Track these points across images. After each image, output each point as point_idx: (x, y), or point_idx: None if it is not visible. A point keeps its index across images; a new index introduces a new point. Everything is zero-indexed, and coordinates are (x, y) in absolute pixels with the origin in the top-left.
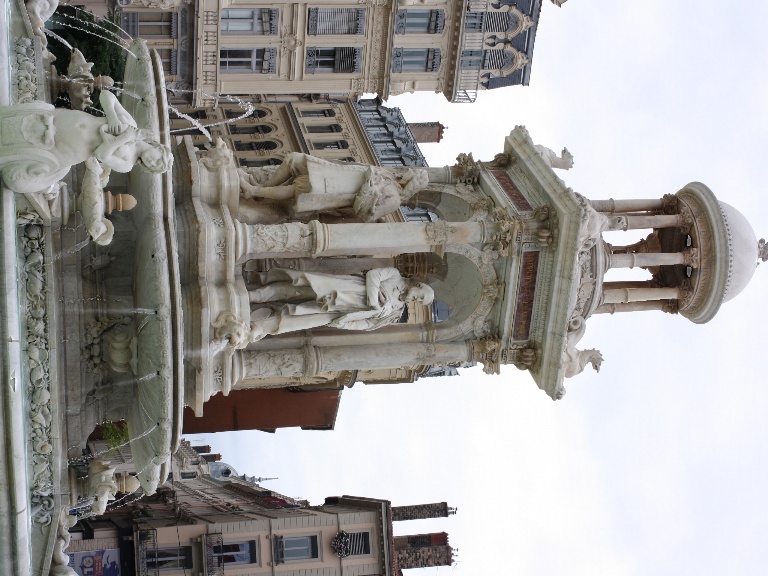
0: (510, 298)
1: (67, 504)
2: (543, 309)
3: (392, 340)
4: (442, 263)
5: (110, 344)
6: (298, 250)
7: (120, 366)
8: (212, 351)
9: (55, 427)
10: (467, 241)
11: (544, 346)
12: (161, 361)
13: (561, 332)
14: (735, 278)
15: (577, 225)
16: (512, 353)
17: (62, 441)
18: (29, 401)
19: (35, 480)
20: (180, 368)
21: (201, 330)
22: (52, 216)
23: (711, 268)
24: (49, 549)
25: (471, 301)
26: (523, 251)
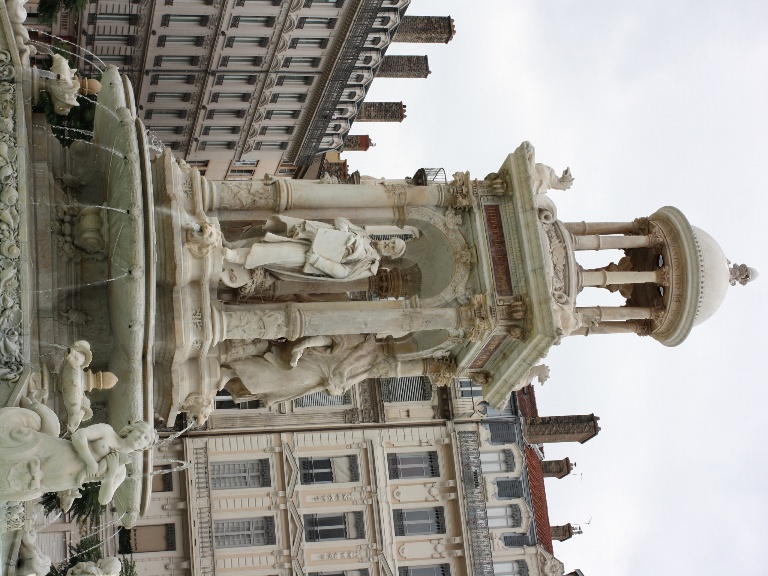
0: (483, 252)
1: (37, 373)
2: (518, 258)
3: (375, 308)
4: (414, 270)
5: (81, 215)
6: (263, 200)
7: (91, 231)
8: (183, 219)
9: (23, 230)
10: (426, 197)
11: (529, 290)
12: (127, 149)
13: (541, 265)
14: (707, 256)
15: (524, 158)
16: (501, 310)
17: (33, 332)
18: None
19: (2, 292)
20: (147, 164)
21: (172, 223)
22: (23, 69)
23: (678, 242)
24: (16, 390)
25: (449, 282)
26: (483, 204)
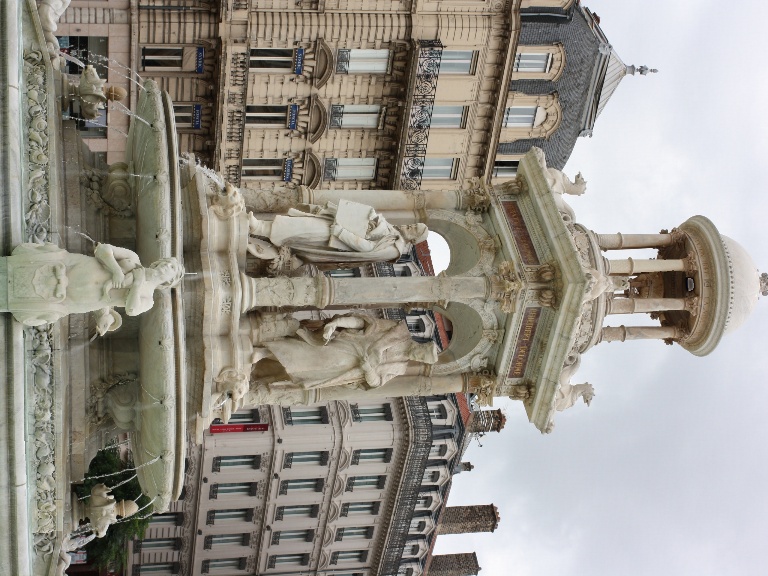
0: (505, 235)
1: None
2: (541, 235)
3: None
4: None
5: (108, 173)
6: (286, 200)
7: None
8: None
9: (52, 146)
10: (445, 198)
11: (555, 253)
12: (150, 88)
13: (563, 231)
14: (730, 247)
15: (534, 158)
16: (529, 275)
17: None
18: (27, 127)
19: (30, 188)
20: None
21: (197, 188)
22: (53, 69)
23: (699, 236)
24: None
25: None
26: (500, 201)
